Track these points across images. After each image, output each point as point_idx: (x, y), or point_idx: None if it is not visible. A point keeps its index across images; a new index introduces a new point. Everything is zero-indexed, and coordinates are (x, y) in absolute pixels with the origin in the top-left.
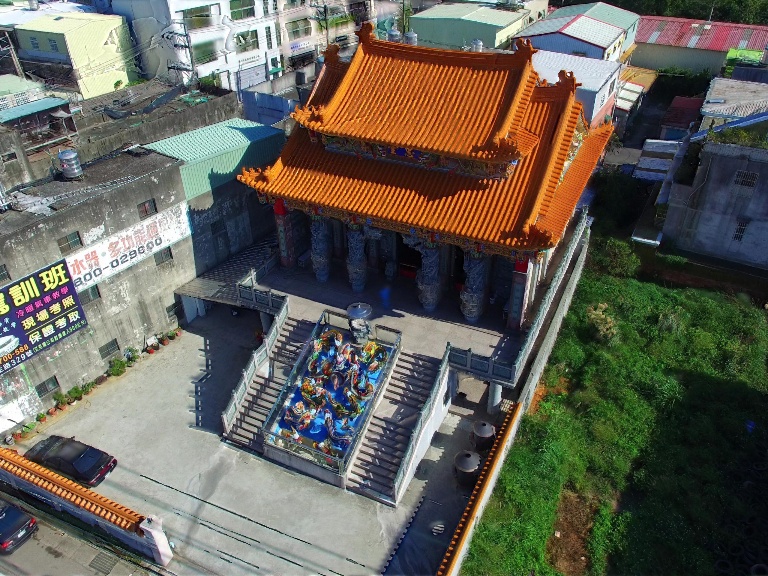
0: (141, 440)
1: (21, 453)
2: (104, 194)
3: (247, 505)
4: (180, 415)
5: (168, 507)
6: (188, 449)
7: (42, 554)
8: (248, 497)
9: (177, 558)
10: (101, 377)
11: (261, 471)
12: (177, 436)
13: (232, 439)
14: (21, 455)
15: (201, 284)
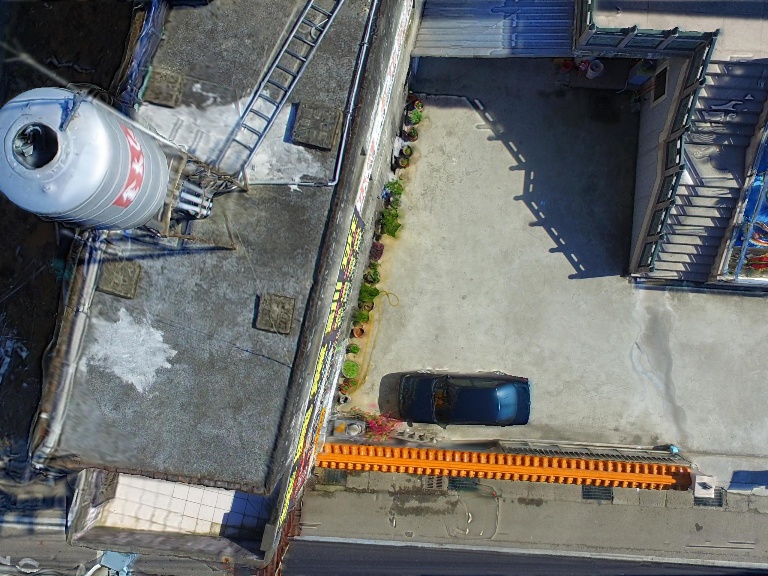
0: (518, 325)
1: (373, 407)
2: (379, 26)
3: (726, 362)
4: (542, 264)
5: (628, 403)
6: (594, 314)
7: (520, 510)
8: (720, 351)
9: (683, 456)
10: (376, 249)
11: (714, 308)
12: (564, 300)
13: (647, 277)
14: (376, 410)
15: (452, 18)
